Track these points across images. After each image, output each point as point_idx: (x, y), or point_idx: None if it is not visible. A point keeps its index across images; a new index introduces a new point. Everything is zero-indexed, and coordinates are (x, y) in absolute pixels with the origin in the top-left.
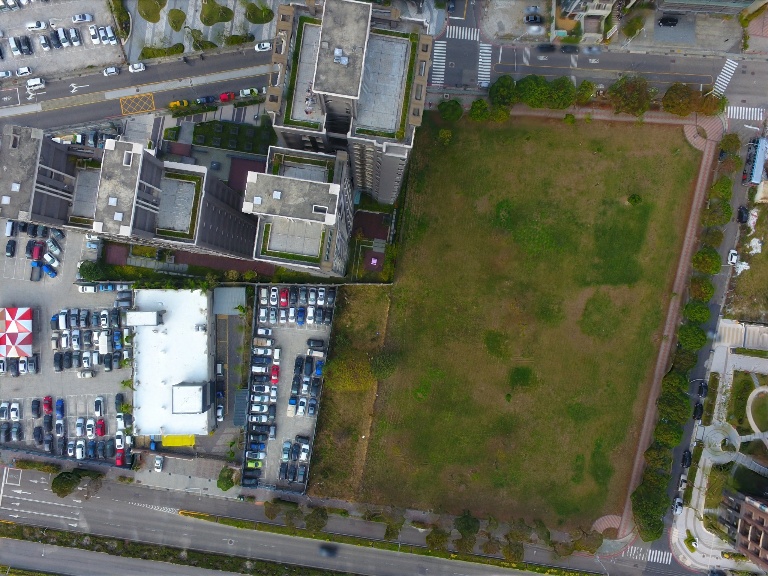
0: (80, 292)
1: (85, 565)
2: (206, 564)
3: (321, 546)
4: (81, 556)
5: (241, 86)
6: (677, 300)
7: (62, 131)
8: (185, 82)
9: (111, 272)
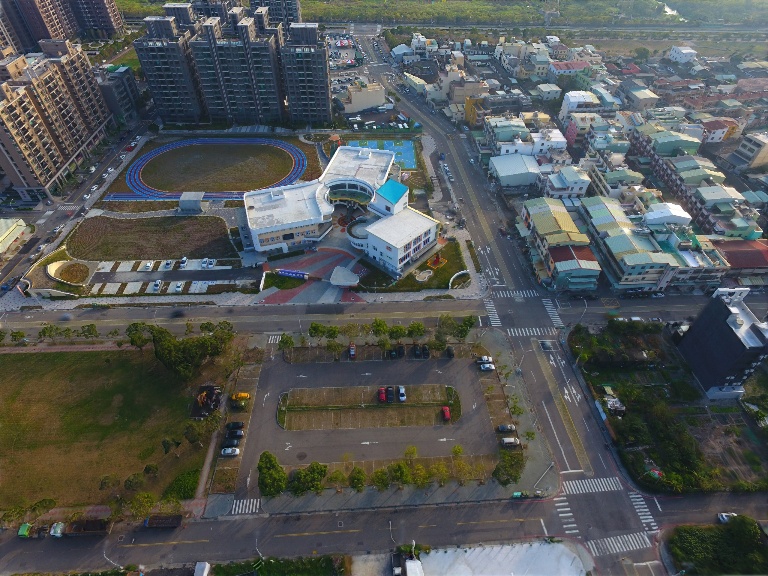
0: None
1: None
2: None
3: None
4: None
5: None
6: (117, 57)
7: None
8: None
9: None
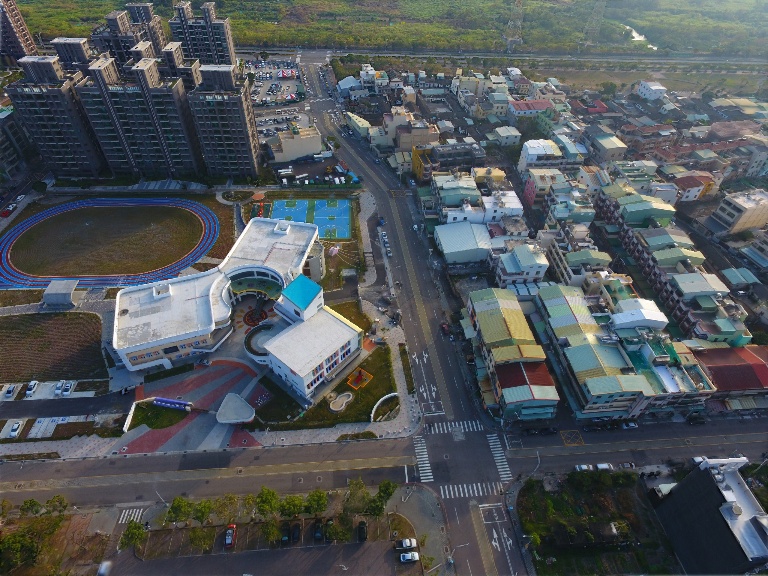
0: None
1: None
2: None
3: None
4: None
5: None
6: None
7: None
8: None
9: None
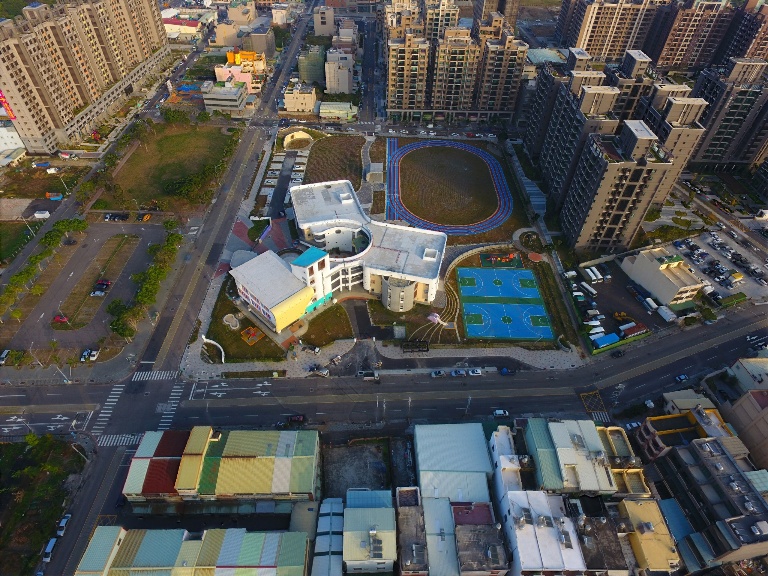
0: None
1: None
2: None
3: None
4: None
5: None
6: None
7: None
8: None
9: None
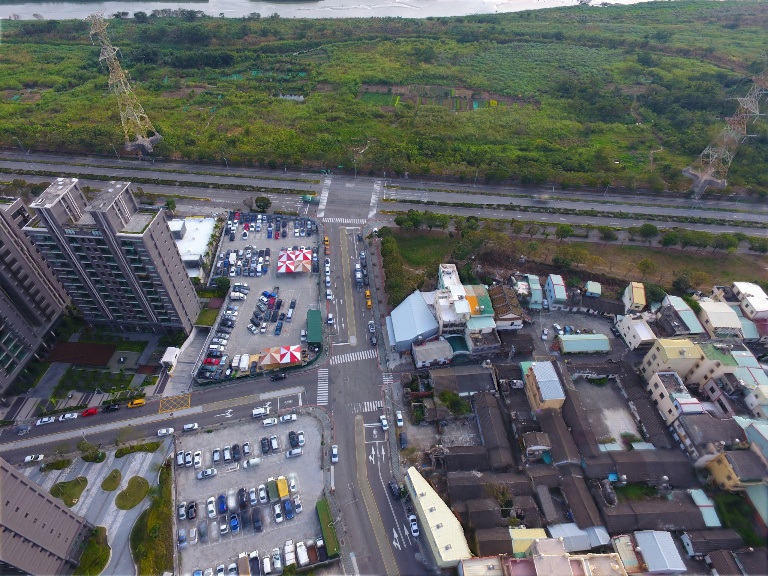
0: (247, 284)
1: (266, 183)
2: (200, 183)
3: (135, 191)
4: (268, 186)
5: (74, 424)
6: None
7: (245, 380)
8: (126, 424)
9: (221, 293)
